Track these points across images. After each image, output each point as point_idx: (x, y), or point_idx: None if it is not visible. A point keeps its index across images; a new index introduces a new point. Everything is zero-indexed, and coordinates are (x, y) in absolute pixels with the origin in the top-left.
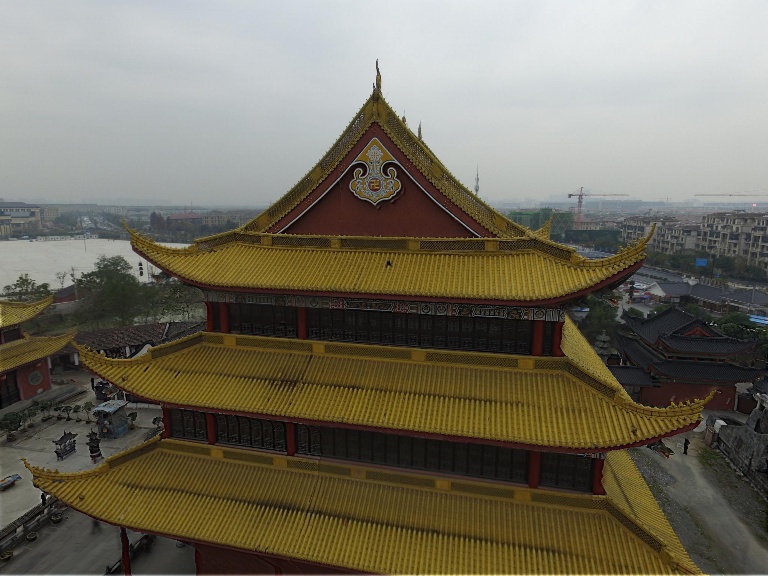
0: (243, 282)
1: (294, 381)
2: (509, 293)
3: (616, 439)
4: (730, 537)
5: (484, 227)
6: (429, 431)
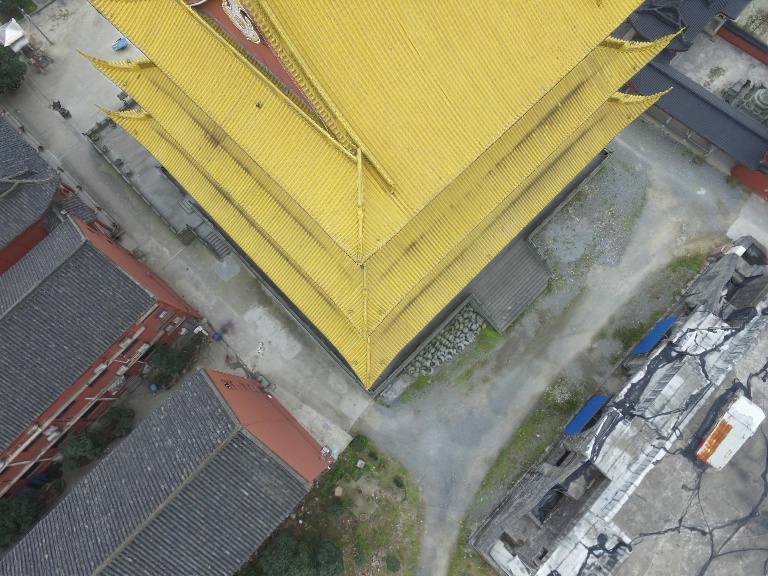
0: (161, 64)
1: (217, 141)
2: (307, 202)
3: (343, 307)
4: (581, 321)
5: (326, 123)
6: (267, 232)
